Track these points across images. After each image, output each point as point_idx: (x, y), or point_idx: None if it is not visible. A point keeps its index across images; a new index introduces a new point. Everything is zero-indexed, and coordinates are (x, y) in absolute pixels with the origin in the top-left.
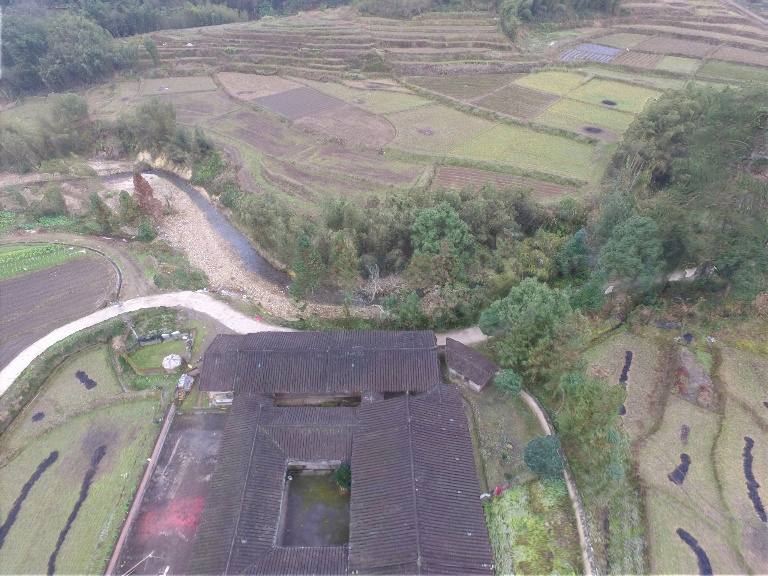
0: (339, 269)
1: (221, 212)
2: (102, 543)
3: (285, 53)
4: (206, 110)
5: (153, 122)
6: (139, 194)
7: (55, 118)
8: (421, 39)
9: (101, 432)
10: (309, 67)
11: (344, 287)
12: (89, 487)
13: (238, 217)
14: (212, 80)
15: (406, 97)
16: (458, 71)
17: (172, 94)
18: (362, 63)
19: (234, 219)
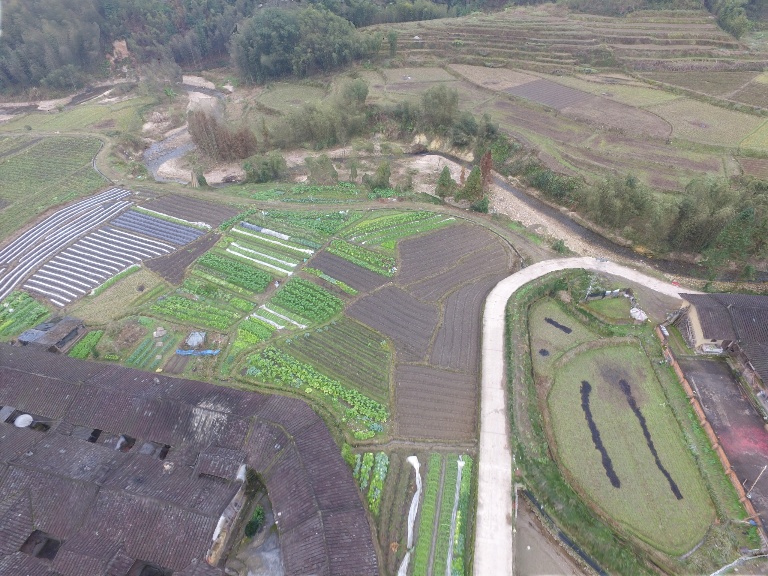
0: (763, 242)
1: (525, 192)
2: (699, 456)
3: (511, 47)
4: (463, 98)
5: (441, 107)
6: (480, 170)
7: (346, 101)
8: (643, 36)
9: (611, 369)
10: (538, 61)
11: (762, 259)
12: (640, 412)
13: (552, 196)
14: (446, 71)
15: (651, 91)
16: (689, 68)
17: (419, 83)
18: (590, 58)
19: (544, 198)
